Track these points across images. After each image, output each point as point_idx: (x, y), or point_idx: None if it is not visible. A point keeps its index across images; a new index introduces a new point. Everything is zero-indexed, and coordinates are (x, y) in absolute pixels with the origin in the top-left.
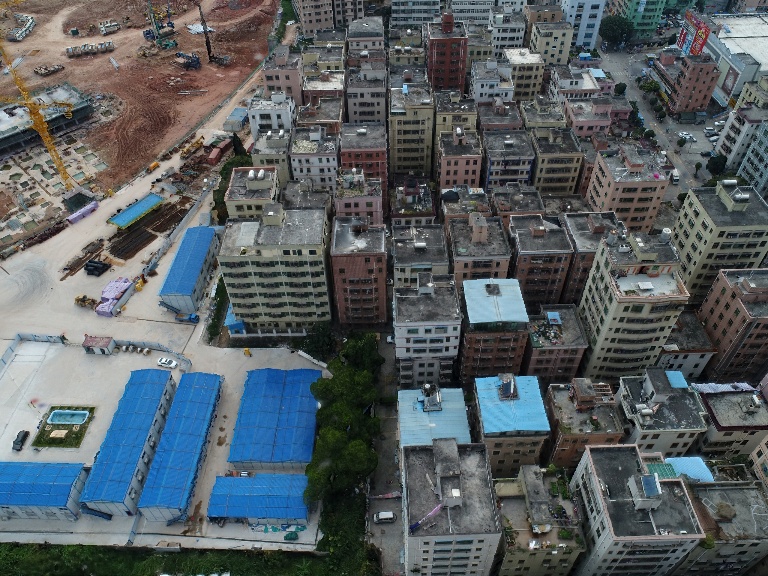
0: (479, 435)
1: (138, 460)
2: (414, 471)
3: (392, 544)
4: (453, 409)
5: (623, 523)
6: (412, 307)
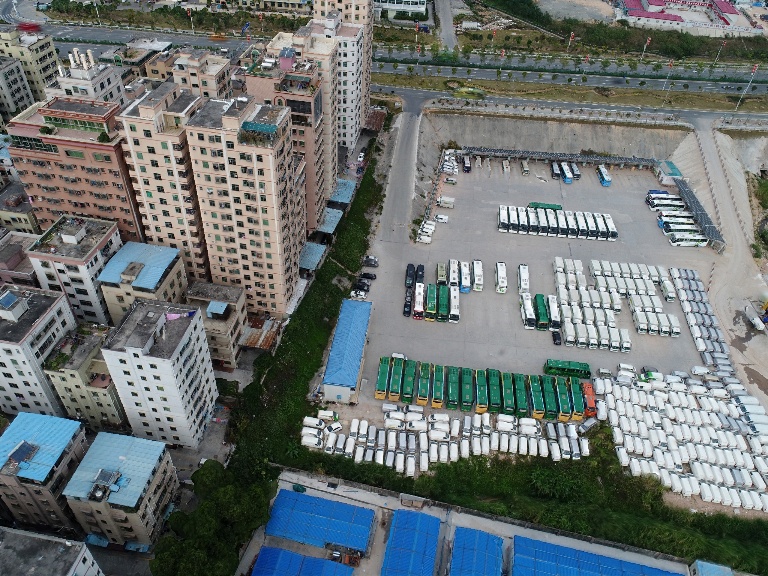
0: (82, 455)
1: (451, 574)
2: (171, 348)
3: (212, 446)
4: (90, 471)
5: (47, 304)
6: (44, 575)
